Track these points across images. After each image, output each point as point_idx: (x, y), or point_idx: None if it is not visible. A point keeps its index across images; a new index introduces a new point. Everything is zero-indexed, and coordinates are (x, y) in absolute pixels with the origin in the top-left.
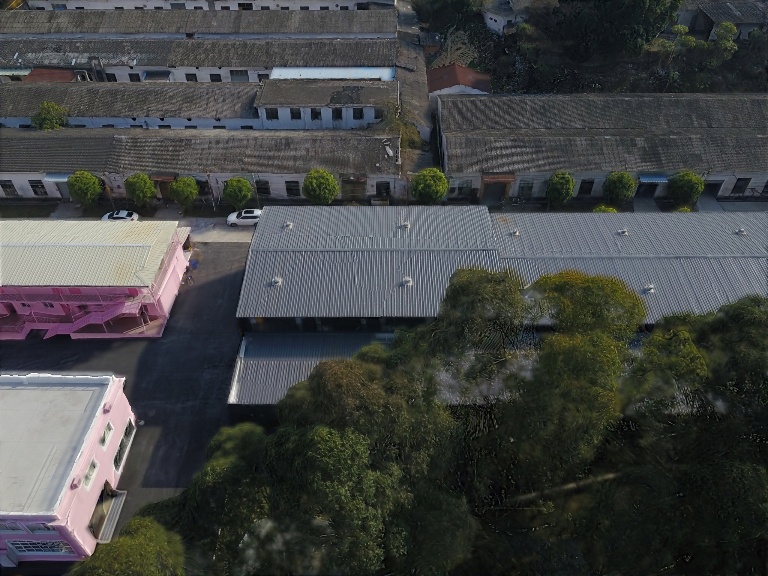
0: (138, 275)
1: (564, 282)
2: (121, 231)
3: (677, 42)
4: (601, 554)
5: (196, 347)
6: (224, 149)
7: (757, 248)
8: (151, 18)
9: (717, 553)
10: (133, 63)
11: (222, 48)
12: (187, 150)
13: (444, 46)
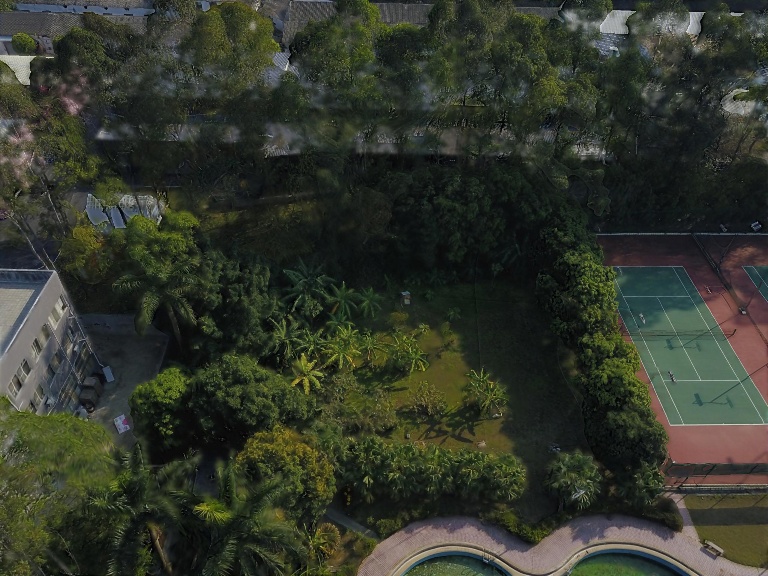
0: None
1: None
2: None
3: None
4: (230, 126)
5: None
6: None
7: None
8: None
9: (299, 142)
10: None
11: None
12: None
13: None
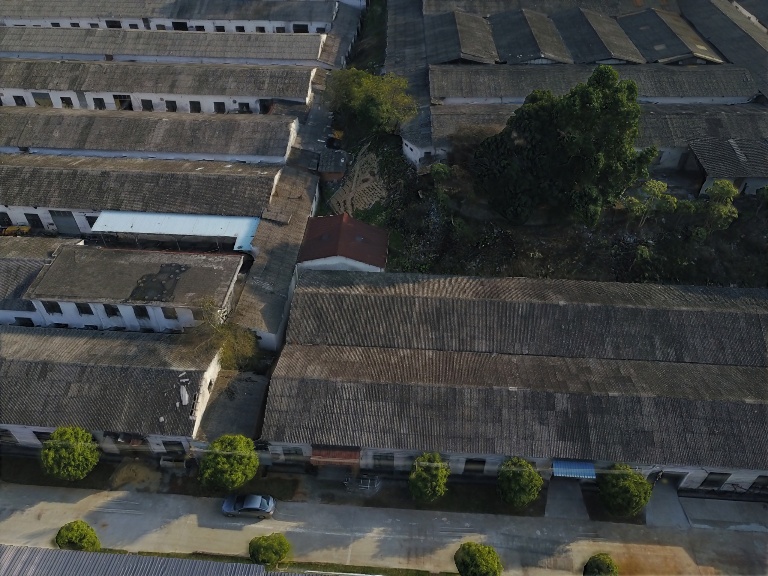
0: None
1: None
2: None
3: (651, 202)
4: None
5: None
6: None
7: None
8: None
9: None
10: None
11: (43, 179)
12: None
13: (350, 172)
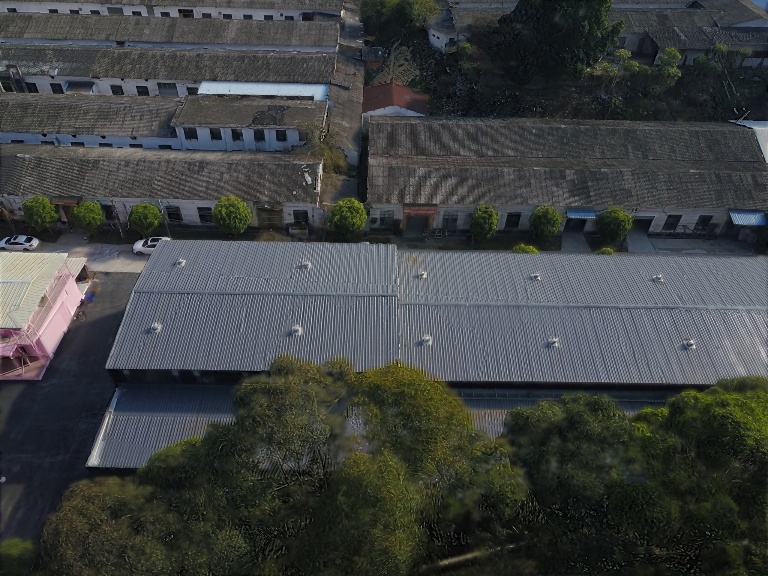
0: (11, 316)
1: (377, 386)
2: (2, 264)
3: (620, 67)
4: None
5: (76, 392)
6: (133, 172)
7: (671, 298)
8: (80, 24)
9: None
10: (54, 73)
11: (150, 59)
12: (94, 172)
13: (387, 62)
